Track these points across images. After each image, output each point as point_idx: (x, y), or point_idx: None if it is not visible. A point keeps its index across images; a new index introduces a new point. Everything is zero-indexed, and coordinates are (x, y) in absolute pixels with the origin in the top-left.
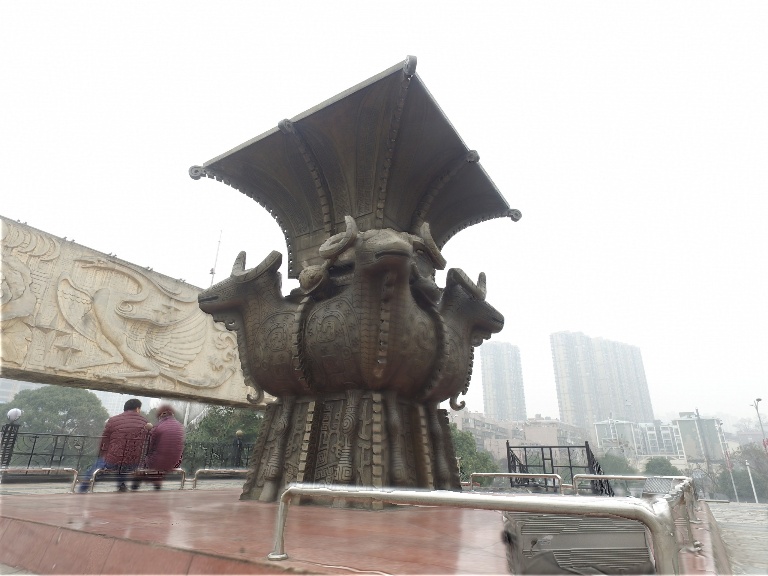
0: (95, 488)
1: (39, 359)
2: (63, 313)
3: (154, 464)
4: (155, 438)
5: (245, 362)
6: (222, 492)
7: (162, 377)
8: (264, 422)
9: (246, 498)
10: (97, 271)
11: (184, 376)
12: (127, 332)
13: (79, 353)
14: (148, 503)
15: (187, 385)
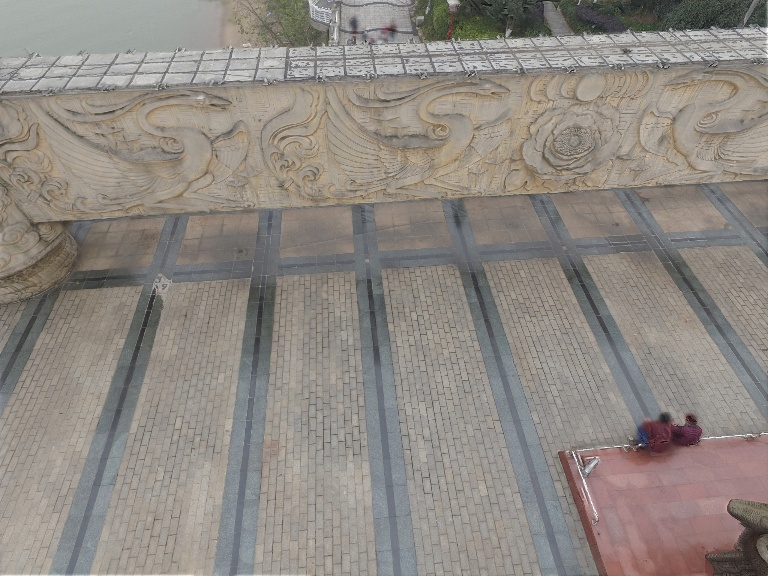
0: (638, 259)
1: (615, 180)
2: (642, 141)
3: (673, 442)
4: (679, 433)
5: (743, 540)
6: (707, 486)
7: (724, 171)
8: (738, 557)
9: (709, 560)
10: (688, 87)
11: (751, 167)
12: (701, 144)
13: (648, 168)
14: (658, 547)
15: (750, 174)
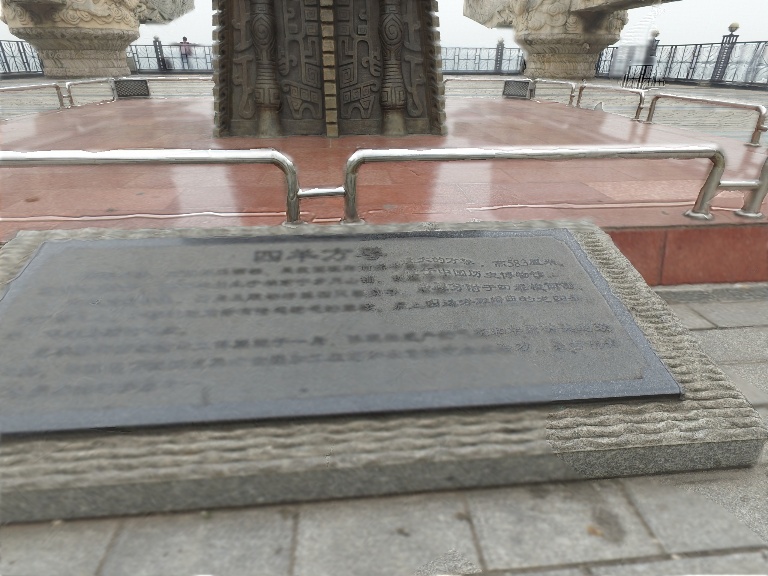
0: None
1: None
2: None
3: None
4: None
5: None
6: (547, 120)
7: None
8: None
9: None
10: None
11: None
12: None
13: None
14: None
15: None
